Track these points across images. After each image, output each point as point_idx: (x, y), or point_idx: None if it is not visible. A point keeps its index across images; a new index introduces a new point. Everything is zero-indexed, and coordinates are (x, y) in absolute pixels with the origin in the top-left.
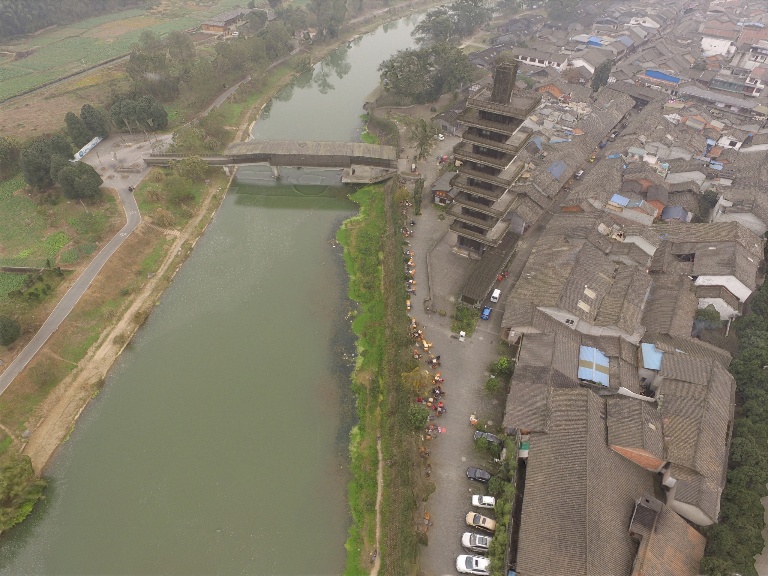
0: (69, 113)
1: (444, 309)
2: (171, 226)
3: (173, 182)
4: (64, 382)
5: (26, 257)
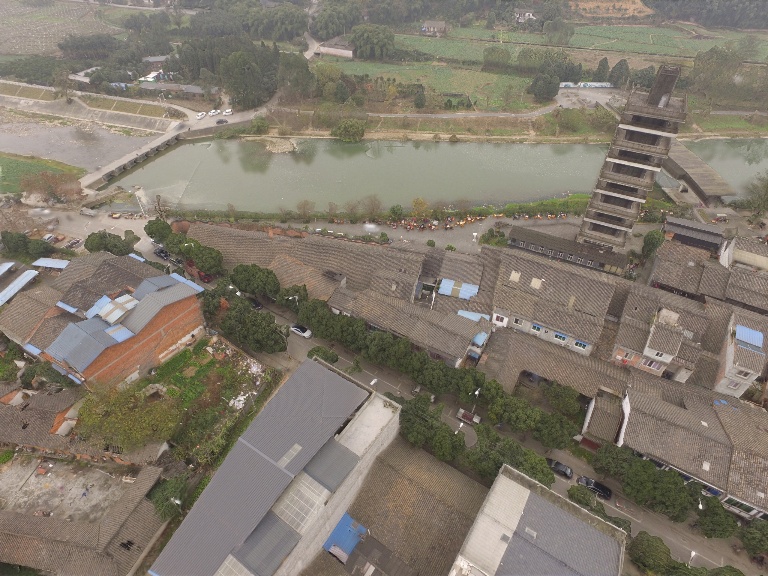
0: (605, 58)
1: None
2: (537, 130)
3: (569, 110)
4: (406, 130)
5: (480, 99)
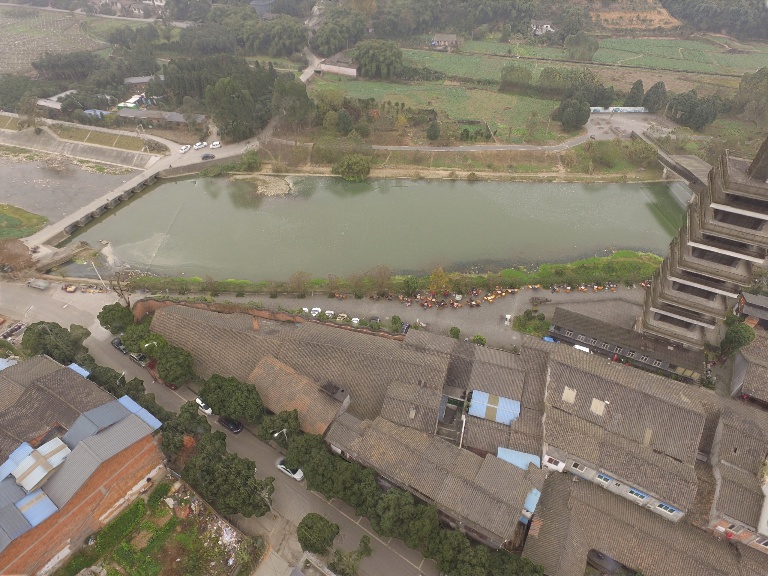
0: (640, 80)
1: (542, 312)
2: (567, 166)
3: (604, 144)
4: (418, 166)
5: (500, 127)
